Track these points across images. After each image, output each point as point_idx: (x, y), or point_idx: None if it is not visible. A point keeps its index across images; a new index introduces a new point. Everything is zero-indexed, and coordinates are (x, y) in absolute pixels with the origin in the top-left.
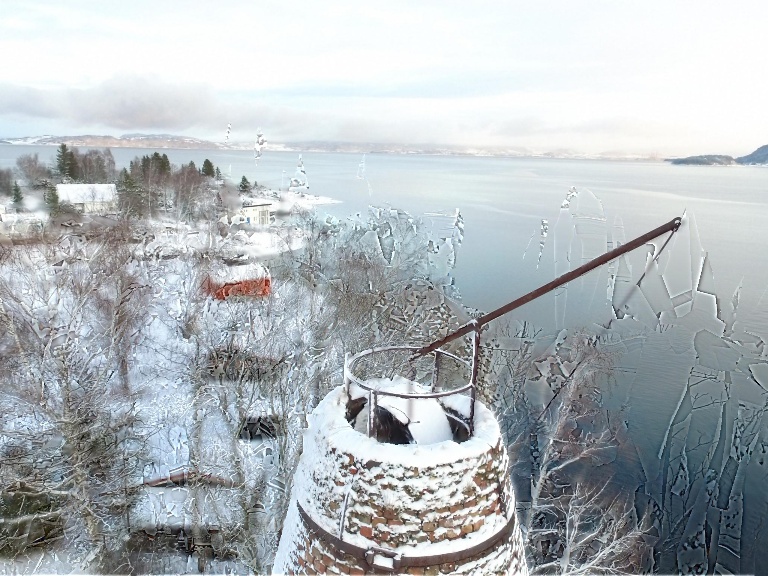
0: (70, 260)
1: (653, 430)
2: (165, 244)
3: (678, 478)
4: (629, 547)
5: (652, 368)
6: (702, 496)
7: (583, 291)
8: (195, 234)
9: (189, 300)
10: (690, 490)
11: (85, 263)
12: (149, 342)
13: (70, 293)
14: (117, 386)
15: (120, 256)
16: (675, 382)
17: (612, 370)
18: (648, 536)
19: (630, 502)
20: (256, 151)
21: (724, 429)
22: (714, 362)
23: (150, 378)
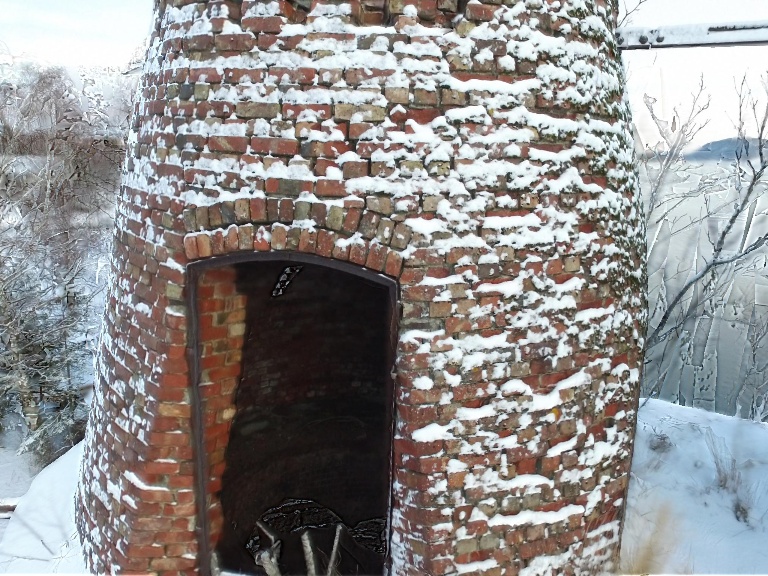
0: None
1: None
2: (106, 84)
3: (657, 310)
4: None
5: None
6: (675, 363)
7: None
8: None
9: None
10: (664, 352)
11: (16, 108)
12: (89, 177)
13: None
14: (52, 216)
15: (55, 90)
16: None
17: None
18: None
19: None
20: None
21: (696, 295)
22: None
23: (90, 210)
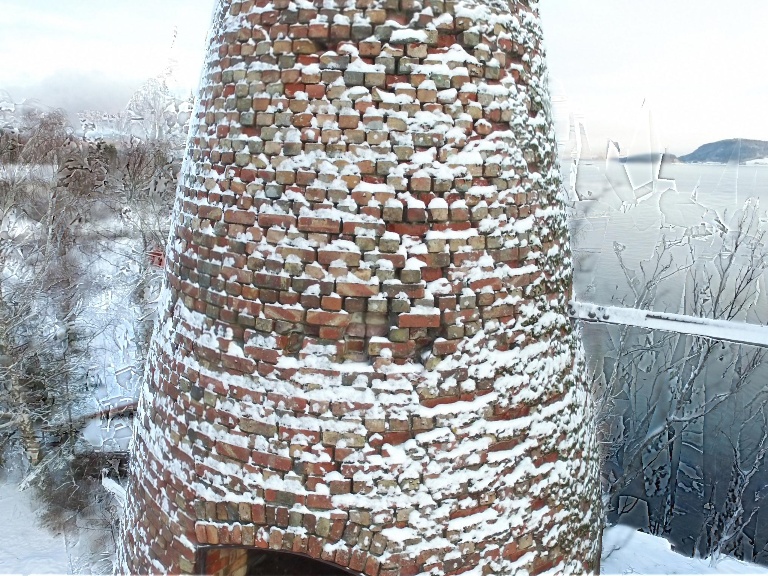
0: (1, 151)
1: None
2: (106, 129)
3: None
4: None
5: None
6: (665, 395)
7: None
8: (139, 120)
9: (133, 182)
10: (654, 386)
11: (18, 153)
12: (90, 225)
13: (1, 185)
14: (54, 266)
15: (56, 138)
16: (640, 257)
17: (577, 251)
18: (617, 406)
19: (599, 368)
20: None
21: None
22: (680, 219)
23: (91, 259)
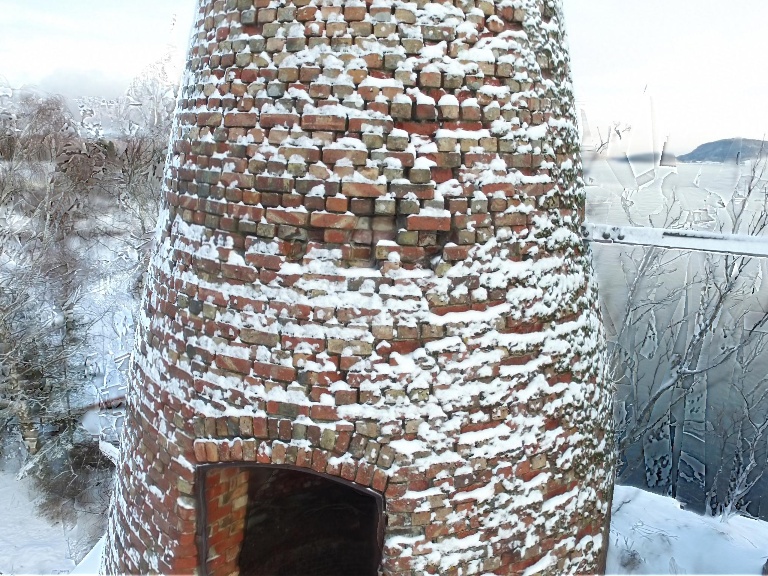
0: None
1: (621, 295)
2: (105, 115)
3: (647, 339)
4: None
5: None
6: None
7: None
8: (138, 106)
9: (132, 167)
10: (655, 375)
11: (15, 139)
12: (88, 210)
13: None
14: (52, 251)
15: (54, 123)
16: None
17: None
18: (619, 392)
19: None
20: None
21: None
22: (682, 202)
23: (89, 244)
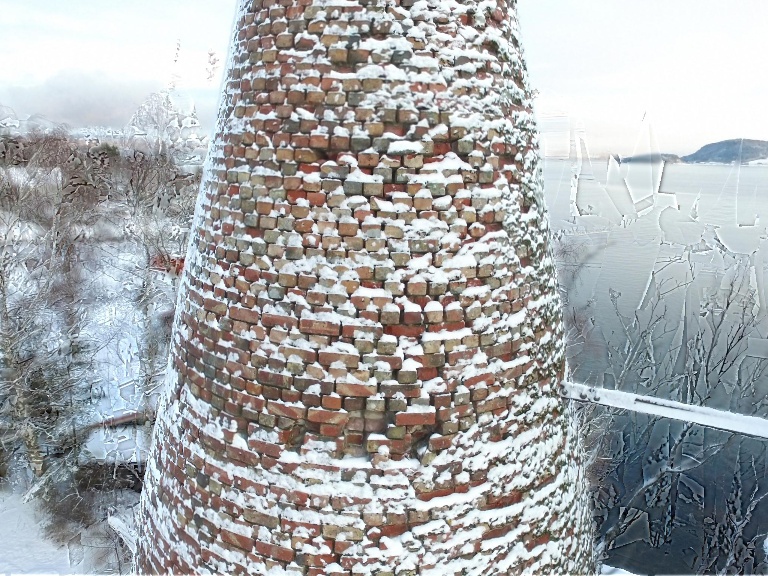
0: (6, 166)
1: (619, 324)
2: (110, 145)
3: None
4: (599, 427)
5: (617, 262)
6: None
7: (547, 189)
8: (143, 135)
9: (137, 198)
10: None
11: (22, 168)
12: (94, 241)
13: (6, 200)
14: (59, 283)
15: (60, 154)
16: (640, 272)
17: (577, 266)
18: (617, 421)
19: (599, 384)
20: (208, 71)
21: (685, 340)
22: (679, 237)
23: (95, 276)
